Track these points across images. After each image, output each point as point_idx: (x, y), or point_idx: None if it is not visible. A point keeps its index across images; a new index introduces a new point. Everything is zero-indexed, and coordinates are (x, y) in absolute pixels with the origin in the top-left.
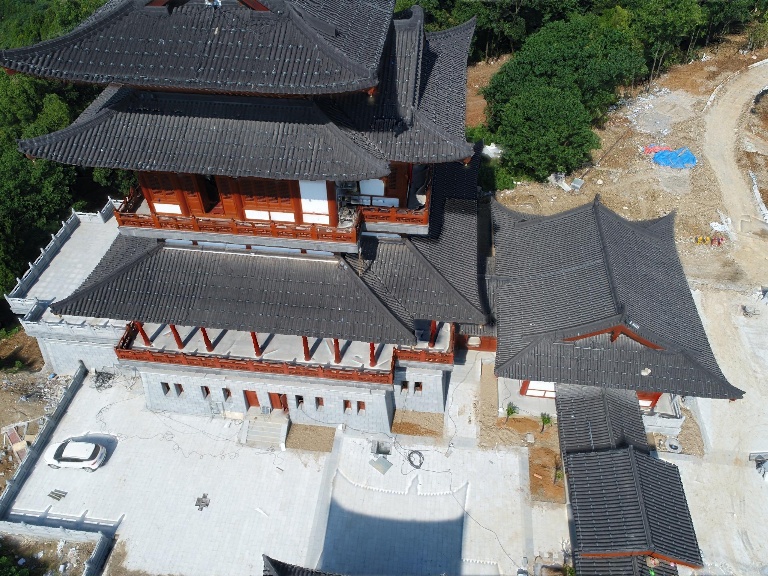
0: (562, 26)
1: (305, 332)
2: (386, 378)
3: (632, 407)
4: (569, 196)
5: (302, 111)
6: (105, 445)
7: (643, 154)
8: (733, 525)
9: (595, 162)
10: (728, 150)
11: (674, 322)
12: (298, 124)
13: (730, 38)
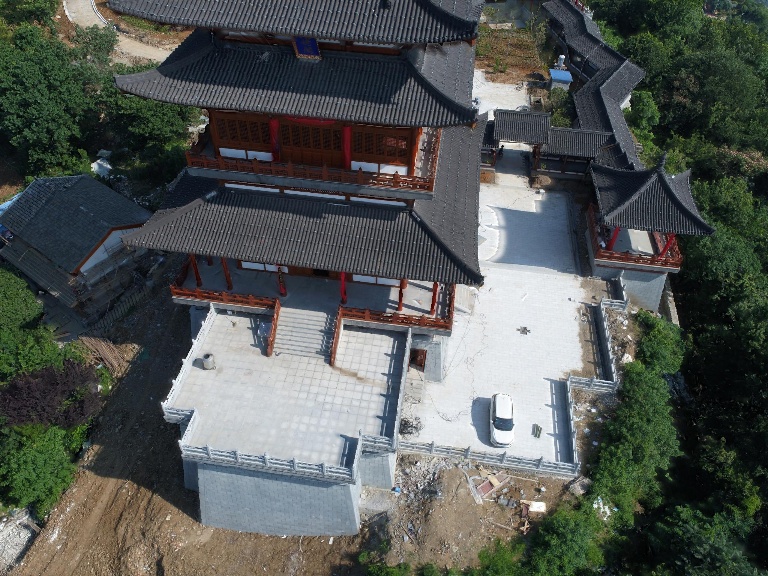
0: None
1: None
2: None
3: None
4: None
5: None
6: (483, 407)
7: None
8: None
9: None
10: None
11: None
12: None
13: None
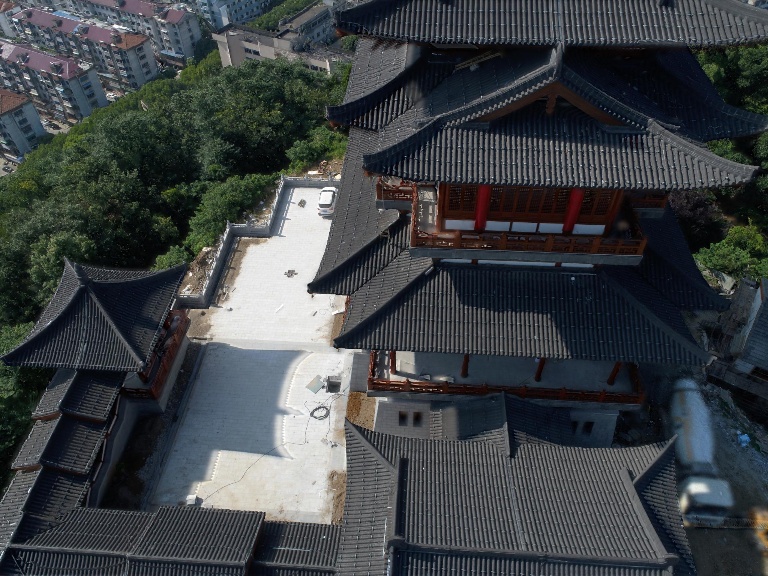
0: None
1: (333, 225)
2: None
3: None
4: None
5: None
6: None
7: None
8: None
9: None
10: None
11: None
12: None
13: None
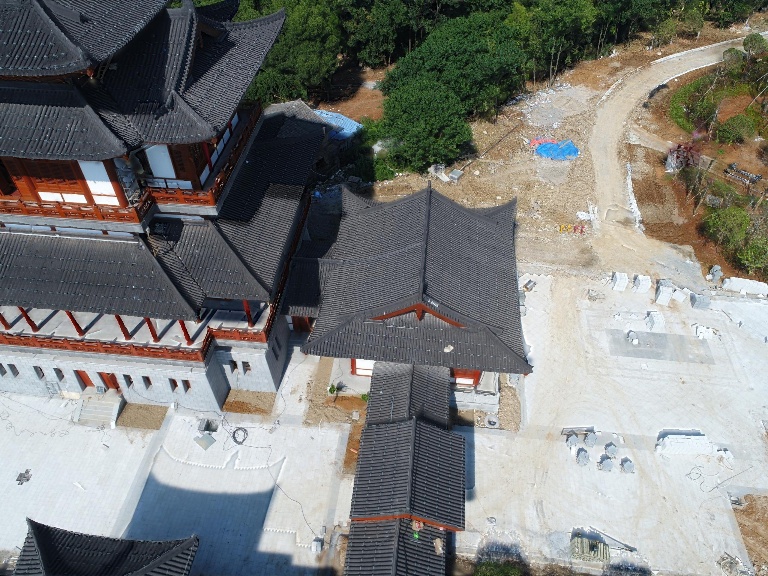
0: (459, 22)
1: (97, 309)
2: (196, 355)
3: (441, 383)
4: (445, 186)
5: (65, 95)
6: None
7: (527, 146)
8: (531, 495)
9: (480, 154)
10: (612, 142)
11: (486, 302)
12: (60, 107)
13: (643, 35)
